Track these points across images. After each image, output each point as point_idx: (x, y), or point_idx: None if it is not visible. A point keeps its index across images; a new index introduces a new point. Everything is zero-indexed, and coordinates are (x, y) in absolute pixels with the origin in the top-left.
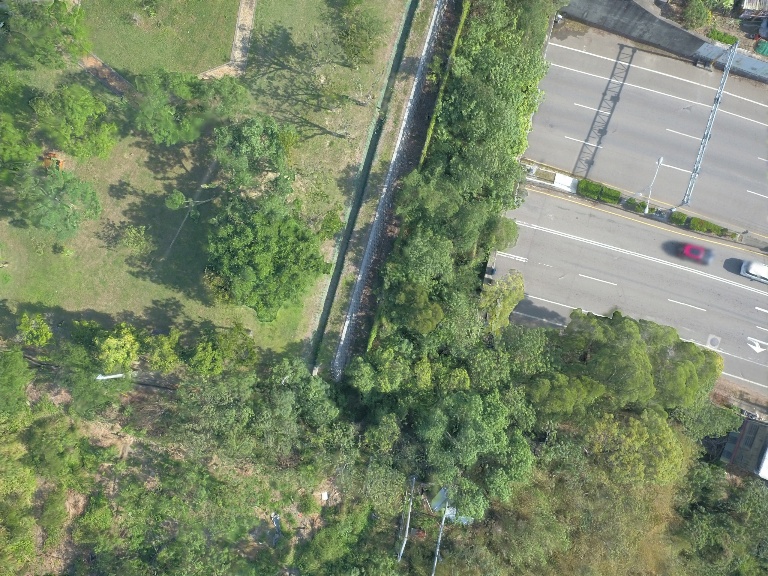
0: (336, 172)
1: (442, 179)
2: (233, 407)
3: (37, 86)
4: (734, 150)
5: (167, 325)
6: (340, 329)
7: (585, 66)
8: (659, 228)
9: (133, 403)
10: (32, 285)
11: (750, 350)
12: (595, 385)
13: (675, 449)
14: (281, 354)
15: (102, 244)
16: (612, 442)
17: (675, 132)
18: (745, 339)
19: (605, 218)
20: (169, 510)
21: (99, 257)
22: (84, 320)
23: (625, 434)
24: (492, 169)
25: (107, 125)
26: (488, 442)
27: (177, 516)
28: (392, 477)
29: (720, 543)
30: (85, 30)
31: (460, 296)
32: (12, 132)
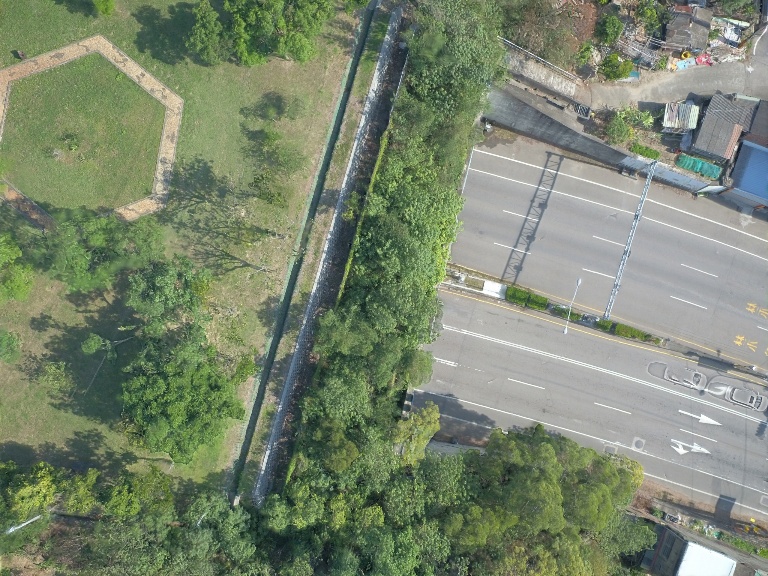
0: (256, 304)
1: (358, 317)
2: (149, 550)
3: None
4: (658, 257)
5: (89, 456)
6: (261, 459)
7: (514, 174)
8: (586, 333)
9: (54, 536)
10: None
11: (673, 452)
12: (508, 516)
13: None
14: (202, 484)
15: (24, 376)
16: None
17: (601, 239)
18: (669, 441)
19: (533, 323)
20: None
21: (21, 389)
22: (2, 462)
23: (534, 569)
24: (405, 310)
25: (23, 270)
26: None
27: None
28: None
29: None
30: (6, 163)
31: (377, 429)
32: None
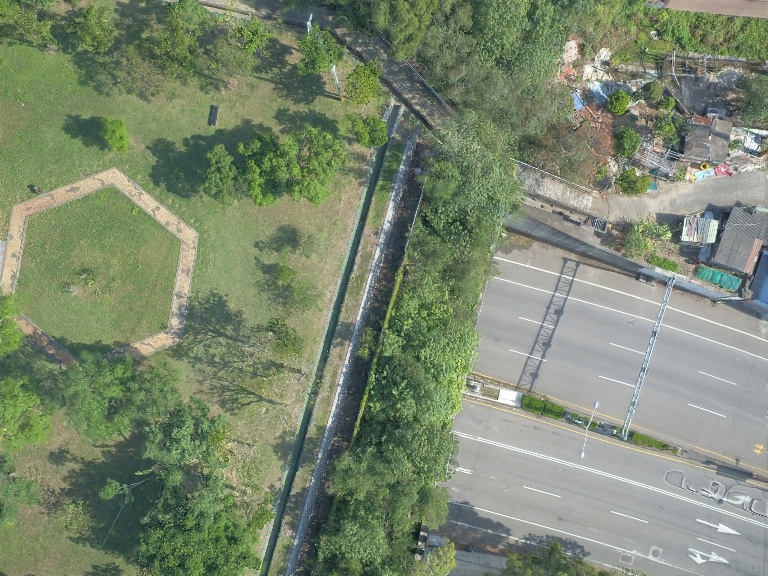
0: (272, 439)
1: (373, 458)
2: None
3: None
4: (676, 364)
5: None
6: None
7: (529, 280)
8: (602, 441)
9: None
10: None
11: (691, 561)
12: None
13: None
14: None
15: (42, 510)
16: None
17: (618, 346)
18: (686, 550)
19: (549, 430)
20: None
21: (40, 523)
22: None
23: None
24: (421, 455)
25: (41, 418)
26: None
27: None
28: None
29: None
30: (24, 299)
31: (392, 568)
32: None
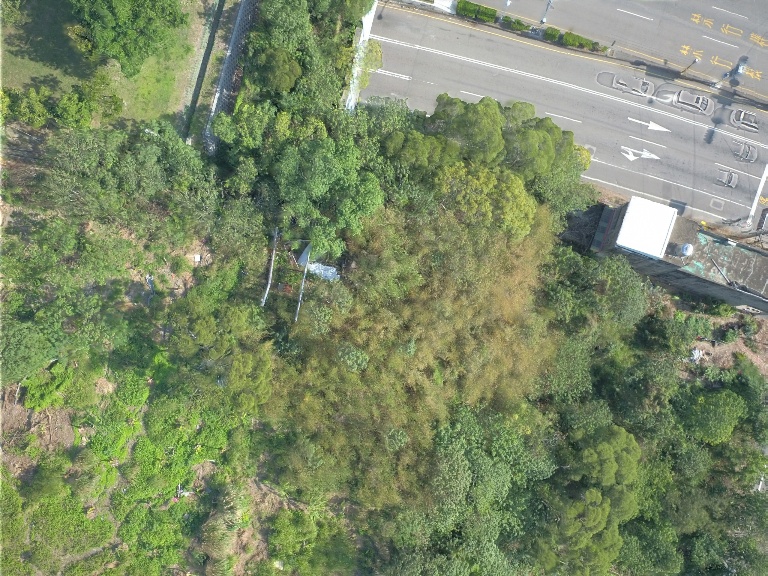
0: None
1: None
2: None
3: None
4: None
5: None
6: (211, 101)
7: None
8: (535, 46)
9: (10, 170)
10: None
11: (624, 158)
12: (449, 141)
13: (524, 198)
14: None
15: None
16: (459, 181)
17: None
18: (619, 148)
19: (484, 38)
20: (48, 275)
21: None
22: None
23: (473, 177)
24: None
25: None
26: (335, 170)
27: (56, 281)
28: (251, 217)
29: (585, 314)
30: None
31: None
32: None
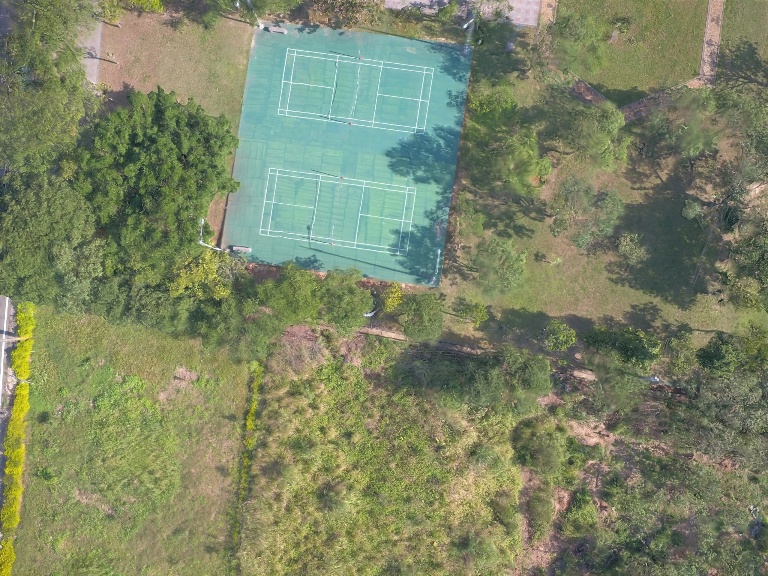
0: None
1: None
2: (755, 406)
3: (516, 101)
4: None
5: (646, 328)
6: None
7: None
8: None
9: None
10: (515, 292)
11: None
12: None
13: None
14: (755, 355)
15: (582, 252)
16: None
17: None
18: None
19: None
20: None
21: (579, 264)
22: (602, 325)
23: None
24: None
25: None
26: None
27: (659, 510)
28: None
29: None
30: None
31: None
32: None
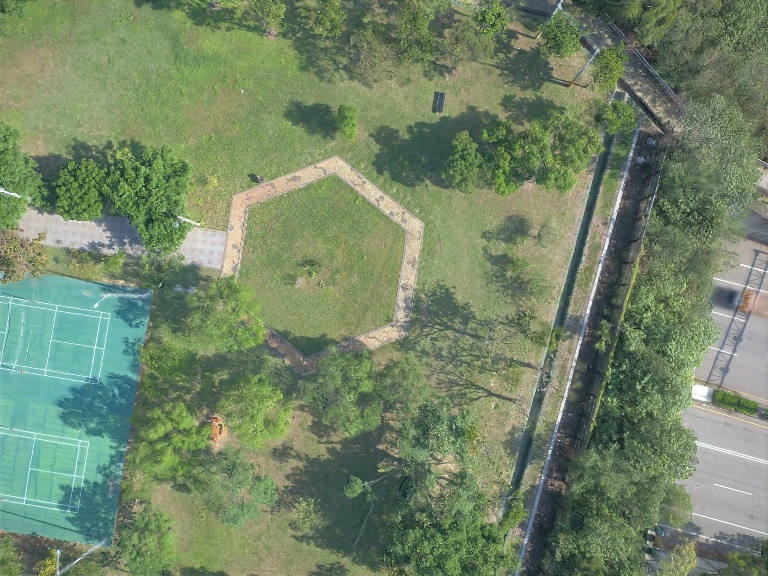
0: (502, 435)
1: (617, 455)
2: None
3: (197, 348)
4: None
5: None
6: None
7: (720, 273)
8: None
9: None
10: (195, 550)
11: None
12: None
13: None
14: None
15: (265, 508)
16: None
17: None
18: None
19: (740, 427)
20: None
21: (262, 522)
22: None
23: None
24: (672, 451)
25: (284, 413)
26: None
27: None
28: None
29: None
30: (245, 291)
31: (632, 568)
32: (185, 415)
